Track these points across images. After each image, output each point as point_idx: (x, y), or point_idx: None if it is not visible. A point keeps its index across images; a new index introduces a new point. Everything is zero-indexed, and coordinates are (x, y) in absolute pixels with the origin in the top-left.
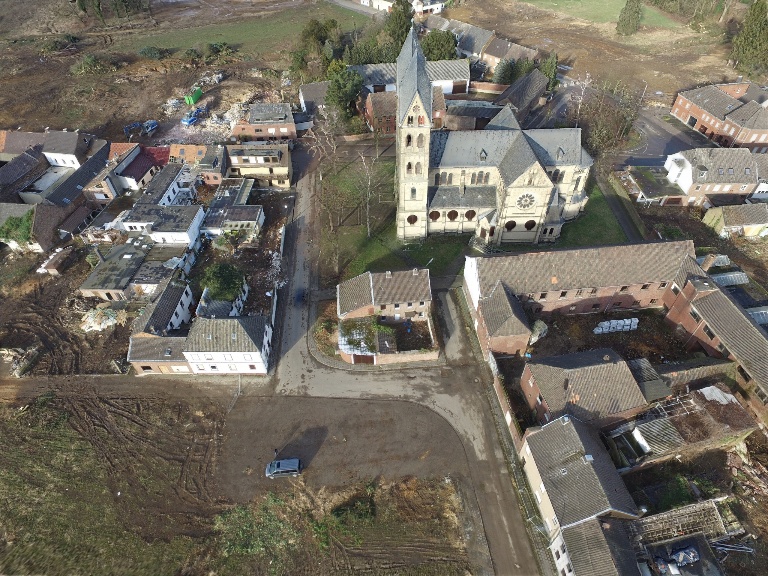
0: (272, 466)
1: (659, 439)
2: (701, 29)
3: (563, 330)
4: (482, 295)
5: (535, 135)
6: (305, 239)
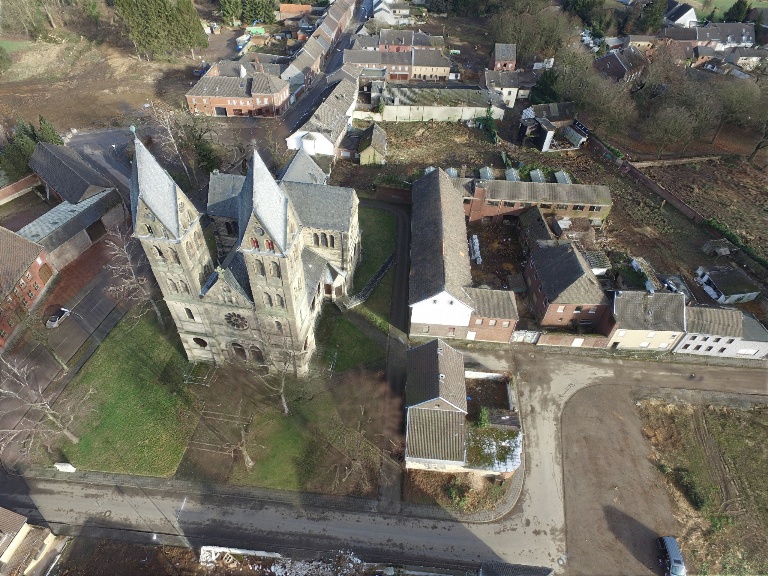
0: (676, 572)
1: (602, 261)
2: (57, 40)
3: (476, 281)
4: (473, 308)
5: (291, 177)
6: (247, 513)
